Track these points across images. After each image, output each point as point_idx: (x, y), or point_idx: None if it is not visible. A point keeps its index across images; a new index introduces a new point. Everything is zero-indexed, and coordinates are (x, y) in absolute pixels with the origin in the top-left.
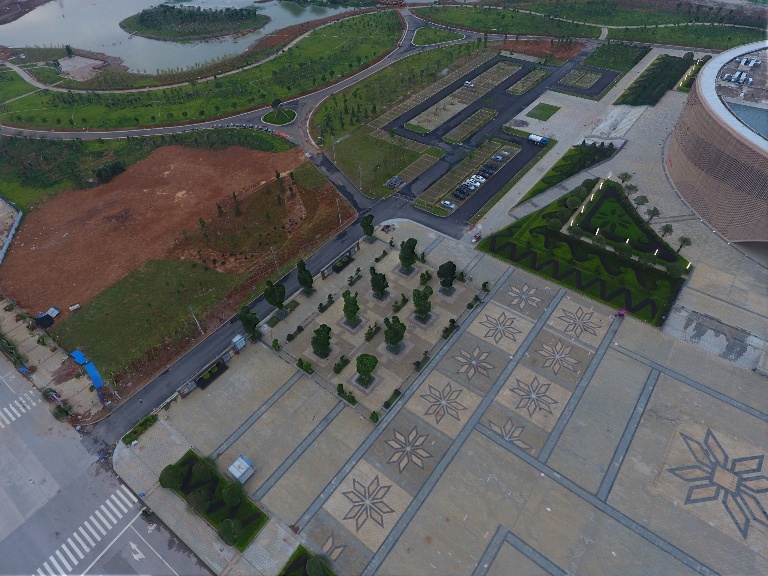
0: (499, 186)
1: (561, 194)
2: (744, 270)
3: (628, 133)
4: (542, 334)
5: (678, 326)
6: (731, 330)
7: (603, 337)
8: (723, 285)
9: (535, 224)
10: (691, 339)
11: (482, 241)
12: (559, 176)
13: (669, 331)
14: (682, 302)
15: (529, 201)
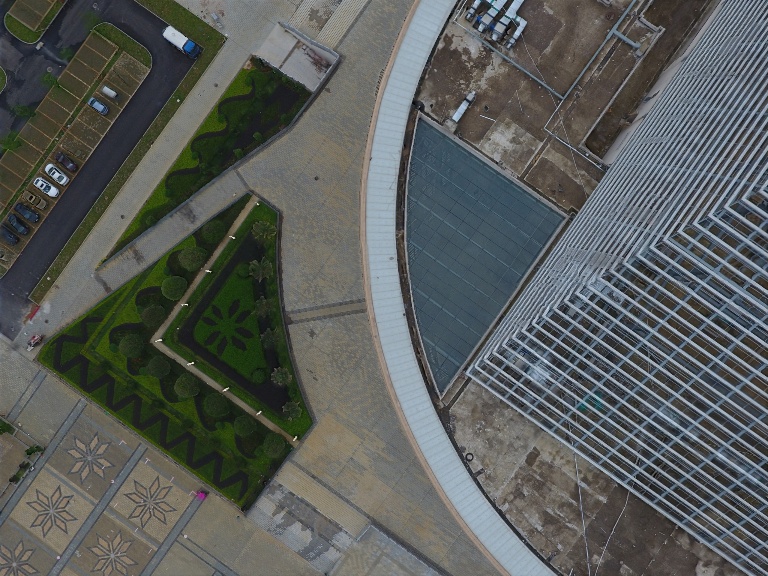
0: (91, 195)
1: (182, 232)
2: (380, 429)
3: (353, 29)
4: (100, 523)
5: (266, 511)
6: (322, 523)
7: (173, 527)
8: (339, 458)
9: (121, 317)
10: (275, 529)
11: (45, 346)
12: (191, 176)
13: (254, 517)
14: (280, 479)
15: (130, 246)
